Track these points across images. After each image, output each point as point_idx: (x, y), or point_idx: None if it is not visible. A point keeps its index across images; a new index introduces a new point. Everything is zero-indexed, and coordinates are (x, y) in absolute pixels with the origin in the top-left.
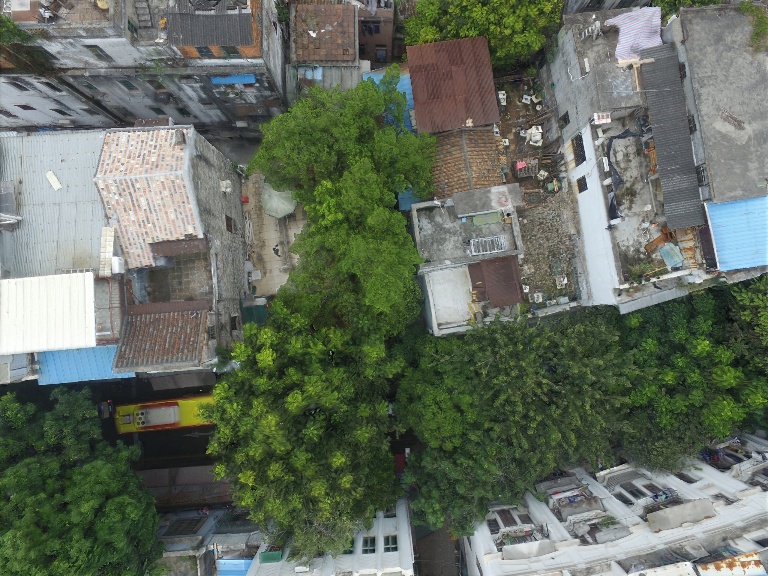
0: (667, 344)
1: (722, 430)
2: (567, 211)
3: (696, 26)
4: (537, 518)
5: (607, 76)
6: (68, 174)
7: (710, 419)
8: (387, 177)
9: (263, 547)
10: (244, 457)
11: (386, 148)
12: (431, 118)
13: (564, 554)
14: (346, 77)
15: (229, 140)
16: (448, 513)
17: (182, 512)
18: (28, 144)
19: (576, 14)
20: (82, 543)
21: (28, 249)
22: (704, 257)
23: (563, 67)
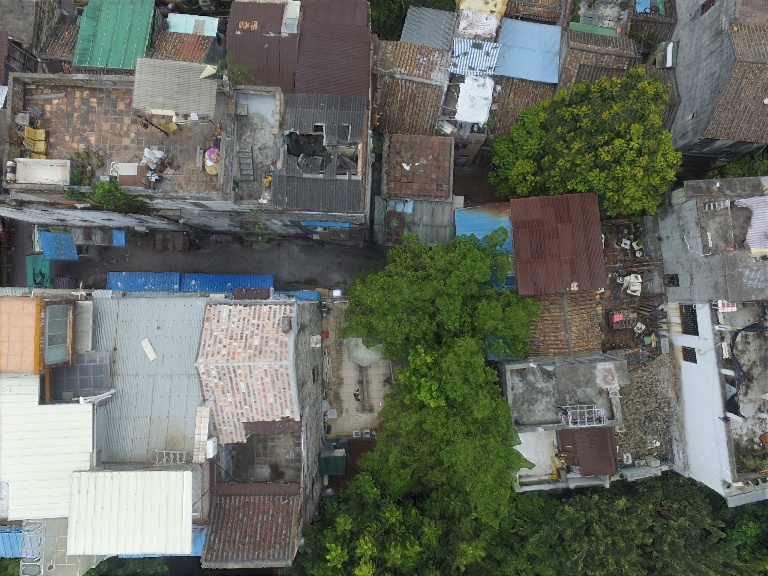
0: (764, 518)
1: None
2: (668, 377)
3: None
4: None
5: (738, 265)
6: (164, 343)
7: None
8: (483, 338)
9: None
10: None
11: (492, 324)
12: (534, 279)
13: None
14: (437, 212)
15: None
16: None
17: None
18: (124, 307)
19: (698, 181)
20: None
21: (120, 424)
22: None
23: (677, 230)
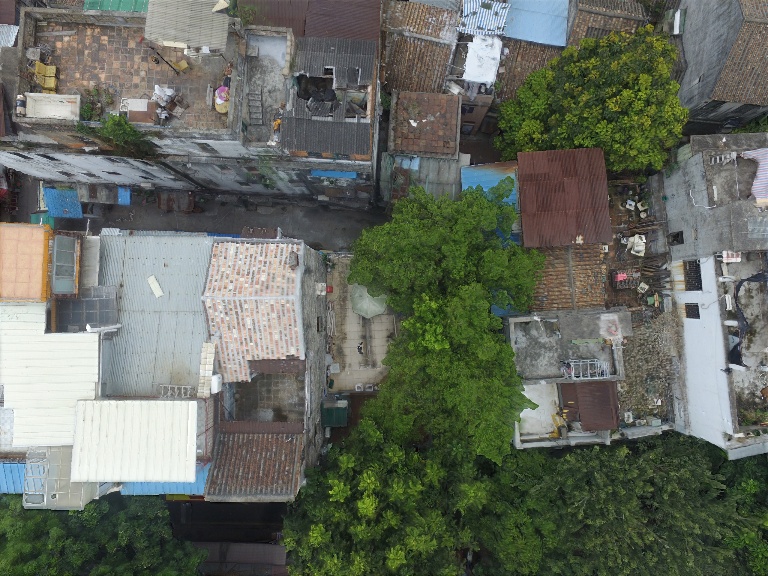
0: (763, 479)
1: None
2: (671, 334)
3: None
4: None
5: (743, 215)
6: (170, 280)
7: None
8: (488, 290)
9: None
10: None
11: (497, 271)
12: (539, 231)
13: None
14: (444, 169)
15: None
16: None
17: None
18: (131, 245)
19: None
20: None
21: (125, 359)
22: None
23: (683, 186)
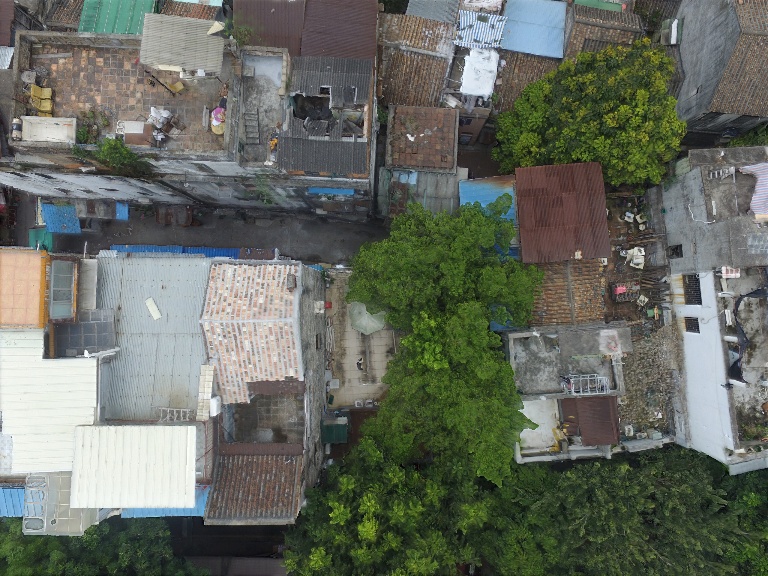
0: (765, 490)
1: None
2: (671, 347)
3: None
4: None
5: (742, 230)
6: (168, 303)
7: None
8: (487, 306)
9: None
10: None
11: (496, 289)
12: (537, 247)
13: None
14: (441, 183)
15: None
16: None
17: None
18: (129, 267)
19: None
20: None
21: (124, 382)
22: None
23: (681, 200)
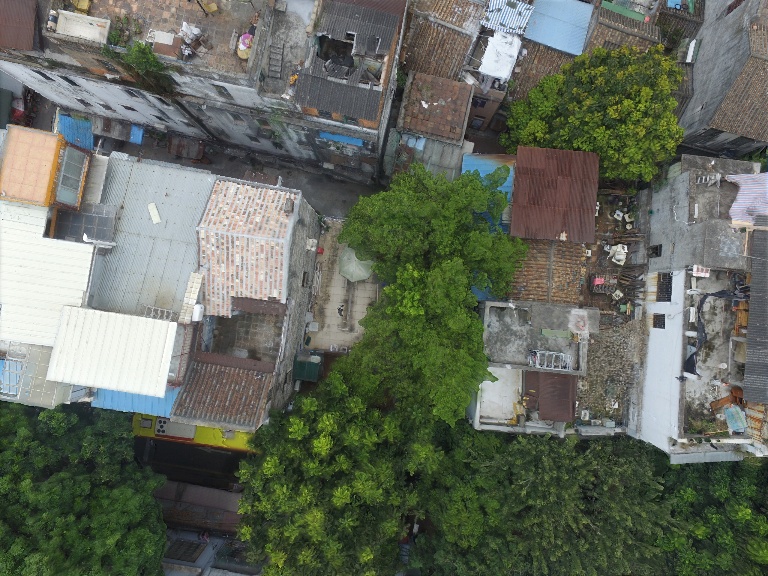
0: (702, 492)
1: None
2: (636, 341)
3: None
4: None
5: (717, 233)
6: (169, 210)
7: None
8: (469, 271)
9: None
10: (278, 533)
11: (480, 251)
12: (526, 223)
13: None
14: (447, 153)
15: (309, 172)
16: None
17: (183, 531)
18: (137, 171)
19: (696, 156)
20: (100, 575)
21: (115, 276)
22: None
23: (668, 202)
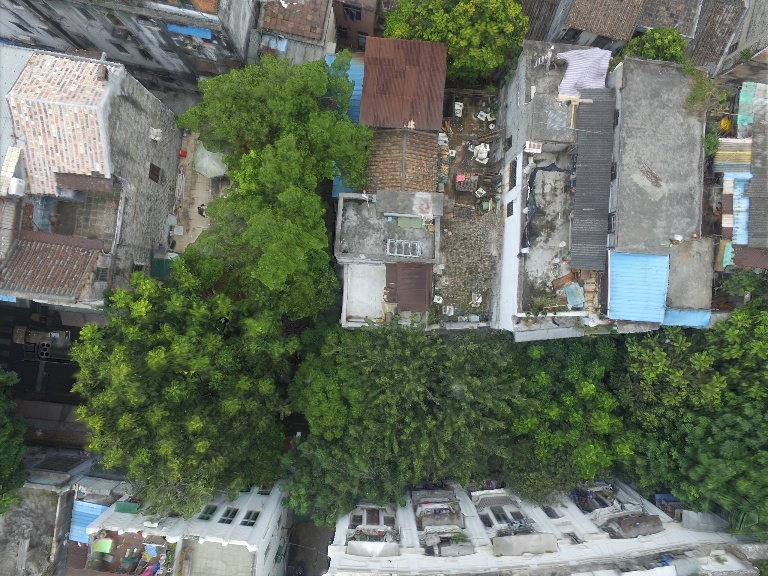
0: (564, 381)
1: (588, 473)
2: (492, 232)
3: (636, 77)
4: (399, 522)
5: (545, 107)
6: None
7: (578, 460)
8: (320, 160)
9: (126, 497)
10: (101, 401)
11: (316, 130)
12: (375, 112)
13: (405, 559)
14: (309, 55)
15: (195, 94)
16: (314, 500)
17: (64, 449)
18: None
19: None
20: None
21: None
22: (600, 302)
23: (515, 91)
